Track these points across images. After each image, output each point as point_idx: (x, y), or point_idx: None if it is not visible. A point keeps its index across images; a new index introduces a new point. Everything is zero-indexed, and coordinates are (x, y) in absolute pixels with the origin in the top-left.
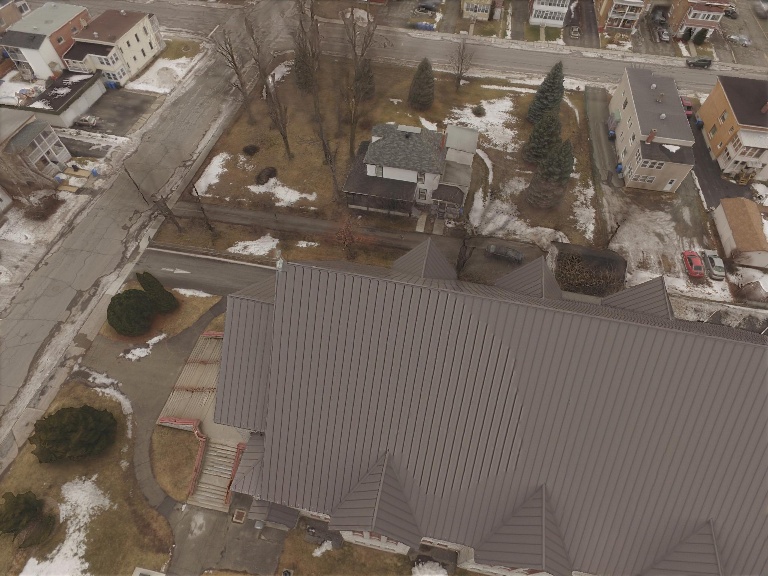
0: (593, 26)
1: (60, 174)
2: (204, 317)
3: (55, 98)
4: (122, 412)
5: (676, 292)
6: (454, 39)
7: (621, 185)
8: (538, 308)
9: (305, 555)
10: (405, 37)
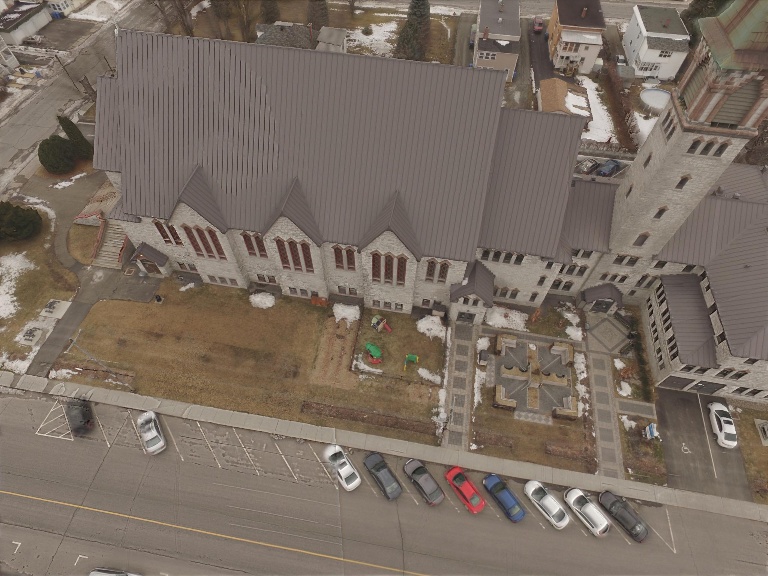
0: None
1: (9, 76)
2: None
3: (6, 21)
4: (48, 217)
5: None
6: None
7: None
8: (273, 47)
9: (174, 290)
10: None
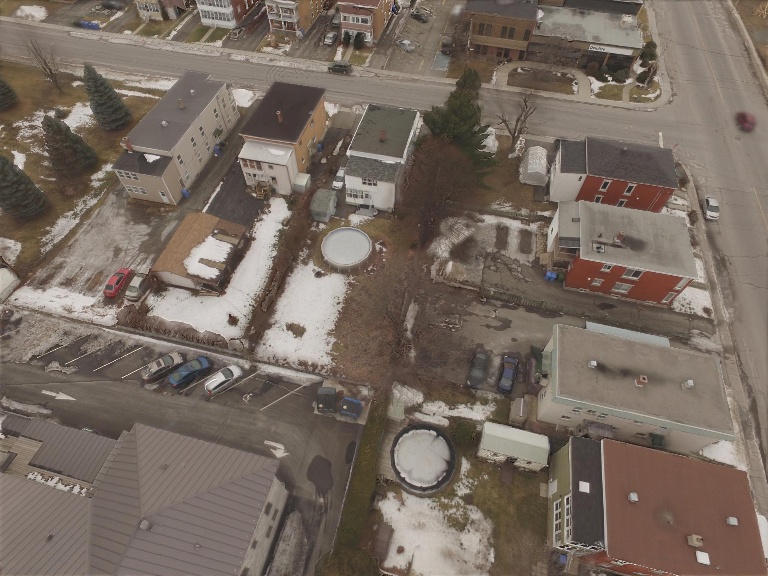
0: (268, 28)
1: None
2: None
3: None
4: None
5: (56, 313)
6: (111, 39)
7: (129, 195)
8: None
9: None
10: (63, 36)
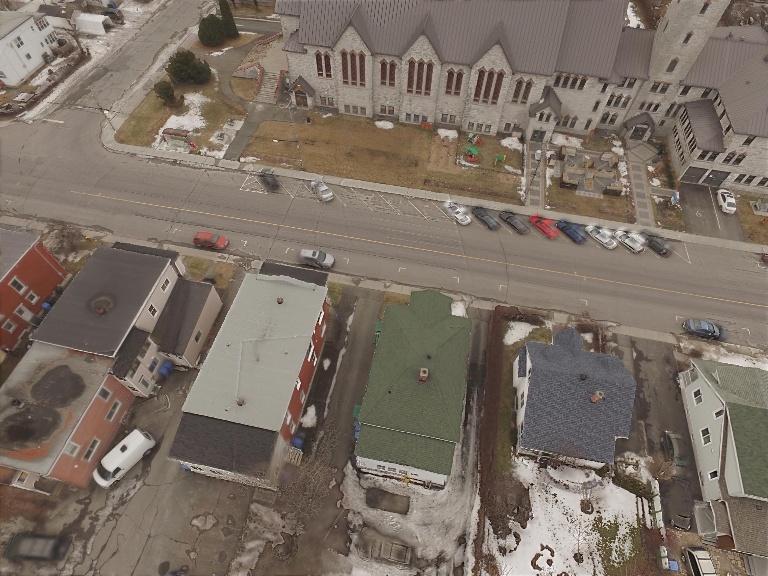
0: None
1: None
2: (255, 41)
3: None
4: (212, 72)
5: None
6: None
7: None
8: None
9: (318, 117)
10: None
